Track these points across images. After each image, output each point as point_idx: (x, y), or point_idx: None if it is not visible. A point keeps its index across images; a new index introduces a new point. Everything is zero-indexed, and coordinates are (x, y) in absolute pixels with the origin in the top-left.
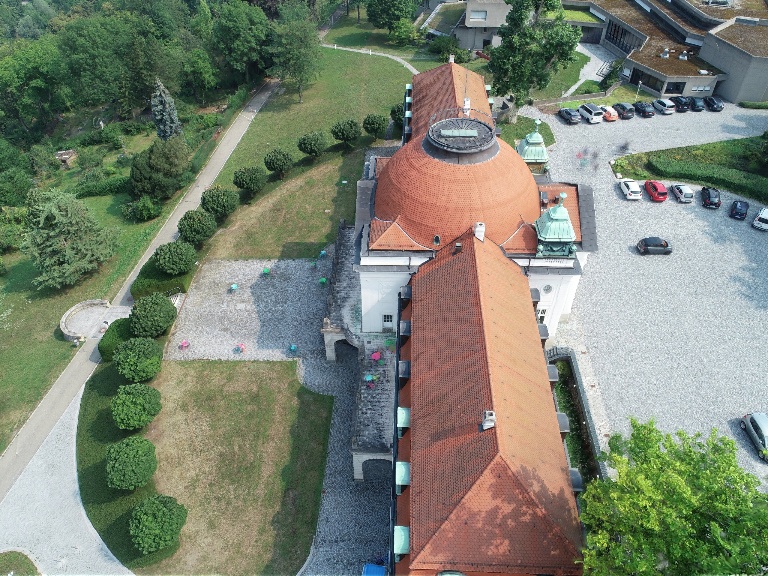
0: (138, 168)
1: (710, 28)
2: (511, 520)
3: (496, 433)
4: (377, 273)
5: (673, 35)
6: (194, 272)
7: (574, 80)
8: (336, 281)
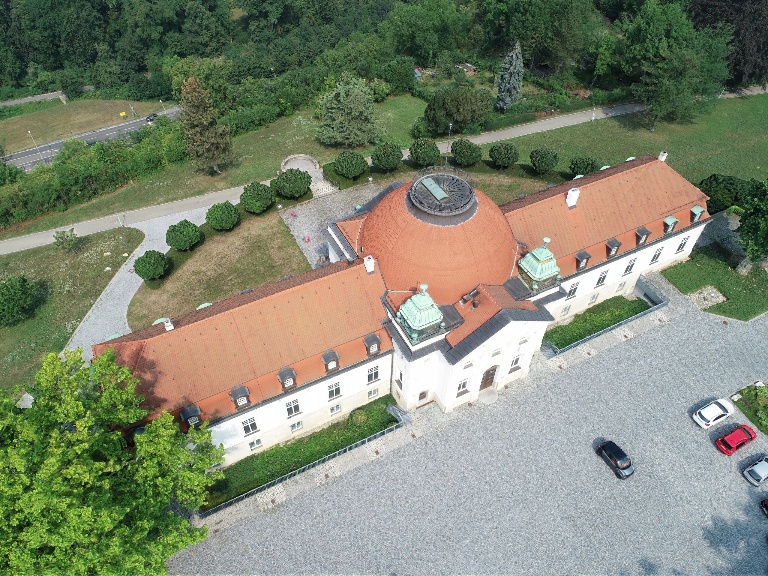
0: (435, 99)
1: None
2: None
3: None
4: None
5: None
6: (361, 183)
7: None
8: None
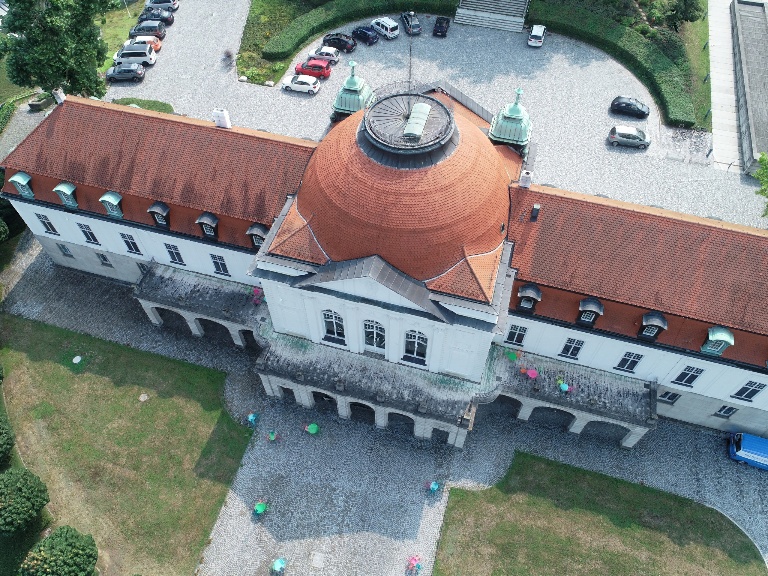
0: None
1: None
2: None
3: None
4: None
5: None
6: None
7: None
8: None
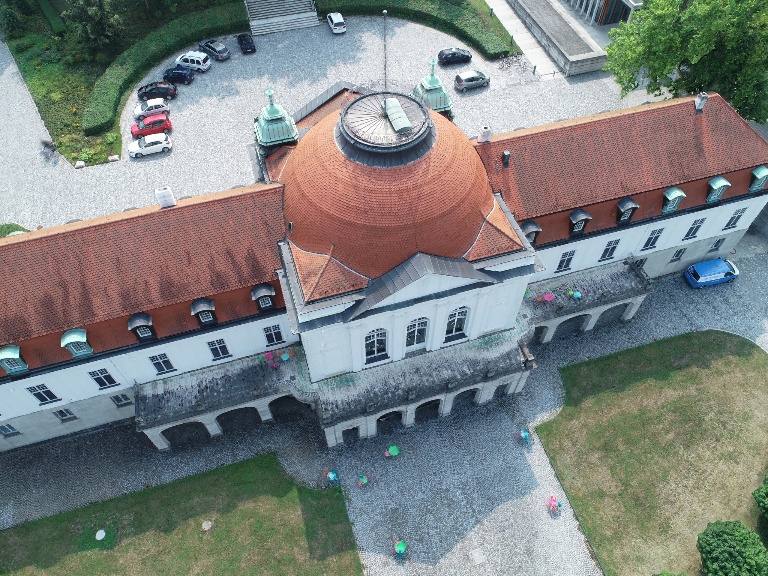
0: None
1: None
2: None
3: None
4: None
5: None
6: None
7: None
8: None
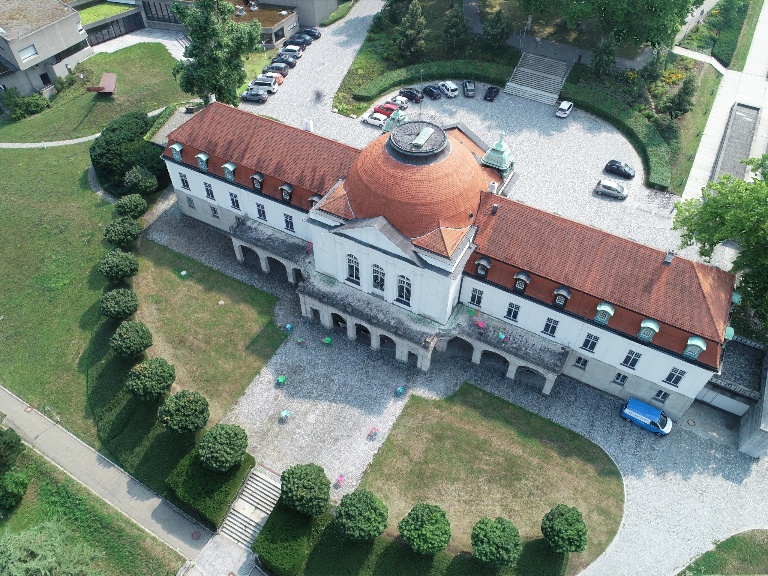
0: None
1: None
2: (715, 284)
3: (679, 257)
4: None
5: None
6: None
7: None
8: None
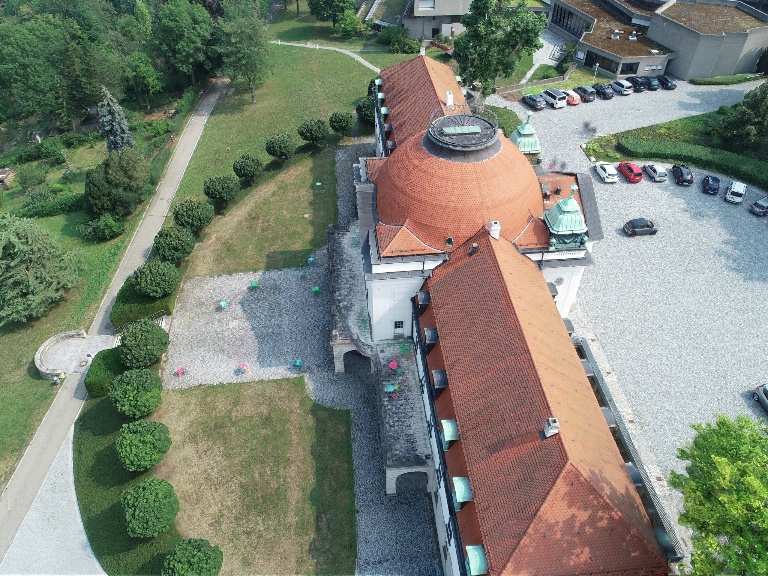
0: (95, 184)
1: (654, 8)
2: (589, 527)
3: (561, 440)
4: (390, 280)
5: (619, 16)
6: (176, 292)
7: (529, 65)
8: (336, 290)
